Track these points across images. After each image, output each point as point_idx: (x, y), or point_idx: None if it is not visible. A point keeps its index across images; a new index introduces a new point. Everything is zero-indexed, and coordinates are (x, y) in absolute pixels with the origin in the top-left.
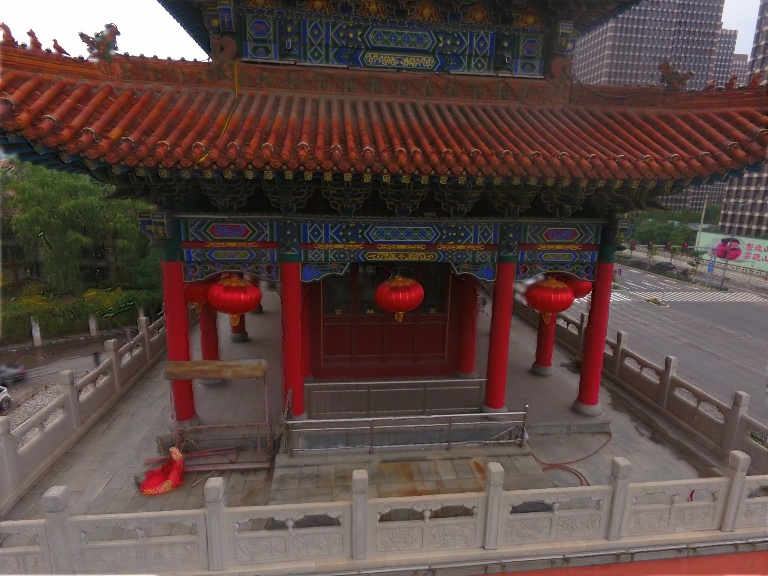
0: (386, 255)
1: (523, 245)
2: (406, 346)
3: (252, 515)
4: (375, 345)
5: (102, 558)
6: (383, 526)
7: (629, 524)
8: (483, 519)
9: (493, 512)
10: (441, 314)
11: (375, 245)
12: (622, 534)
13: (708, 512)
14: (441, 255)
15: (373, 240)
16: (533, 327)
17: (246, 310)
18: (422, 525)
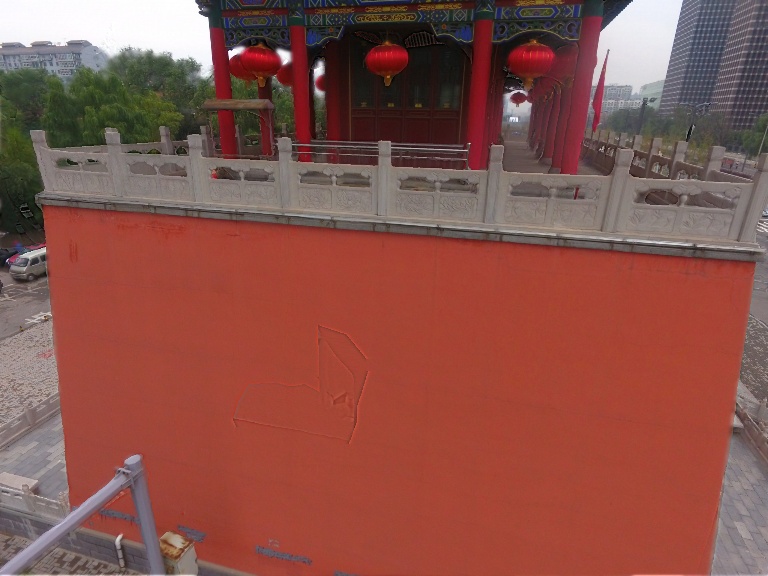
0: (372, 17)
1: (500, 1)
2: (422, 141)
3: (218, 164)
4: (395, 139)
5: (139, 185)
6: (302, 185)
7: (506, 212)
8: (377, 189)
9: (382, 181)
10: (454, 109)
11: (364, 8)
12: (499, 221)
13: (589, 211)
14: (420, 15)
15: (360, 2)
16: (601, 172)
17: (266, 70)
18: (330, 188)
